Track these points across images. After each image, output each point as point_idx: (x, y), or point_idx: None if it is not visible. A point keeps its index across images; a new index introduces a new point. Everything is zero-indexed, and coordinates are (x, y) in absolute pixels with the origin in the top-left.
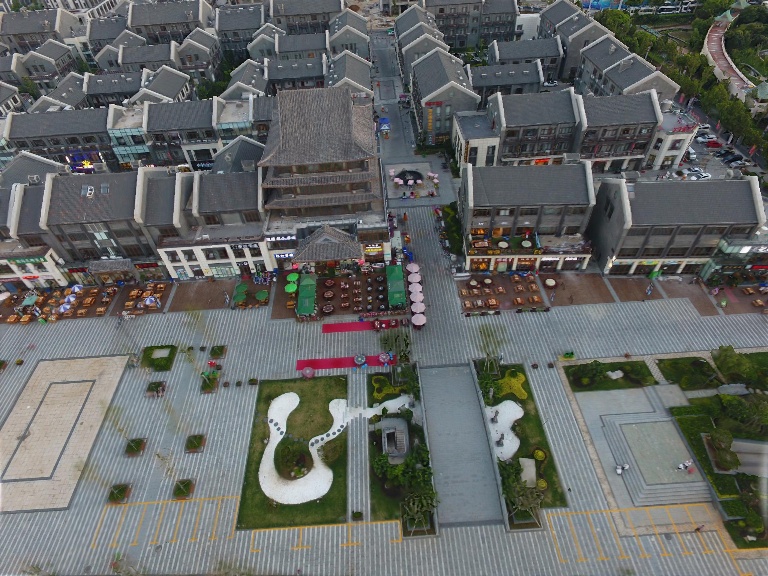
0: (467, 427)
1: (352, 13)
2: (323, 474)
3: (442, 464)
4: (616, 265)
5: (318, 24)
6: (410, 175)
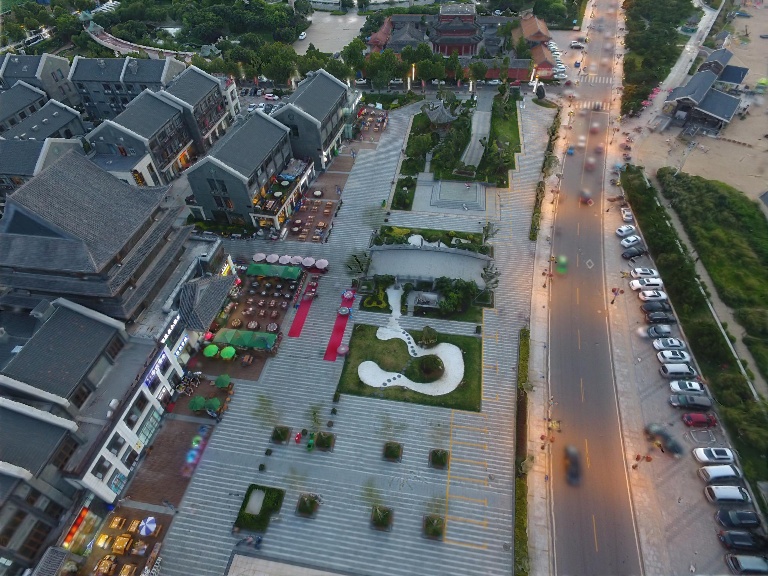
0: (426, 259)
1: None
2: (443, 349)
3: (450, 277)
4: None
5: None
6: None
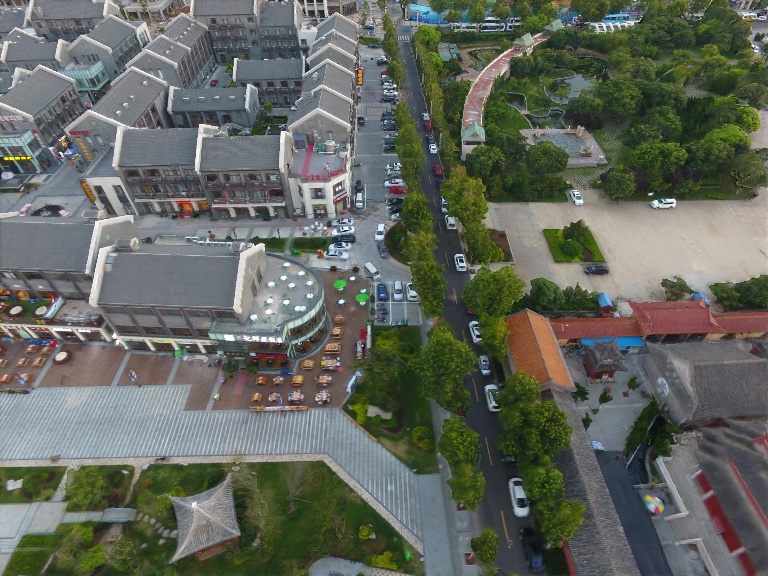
0: None
1: (116, 20)
2: None
3: None
4: (129, 341)
5: (83, 30)
6: (46, 211)
